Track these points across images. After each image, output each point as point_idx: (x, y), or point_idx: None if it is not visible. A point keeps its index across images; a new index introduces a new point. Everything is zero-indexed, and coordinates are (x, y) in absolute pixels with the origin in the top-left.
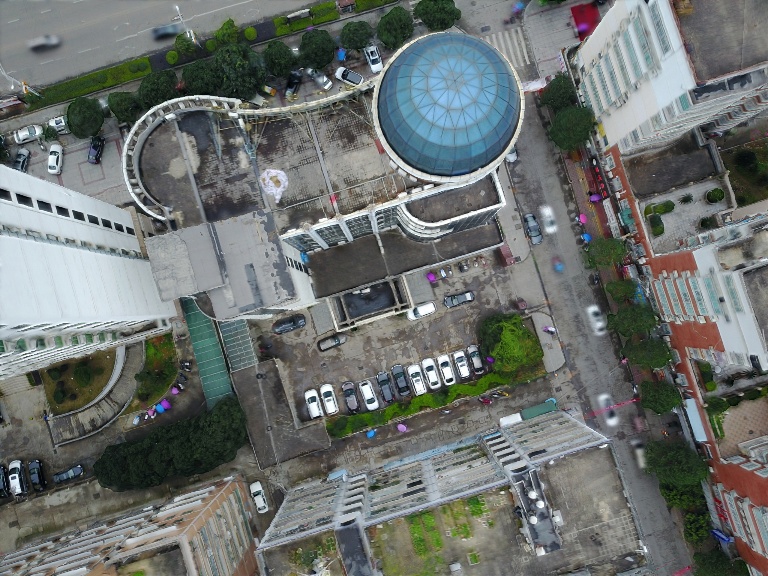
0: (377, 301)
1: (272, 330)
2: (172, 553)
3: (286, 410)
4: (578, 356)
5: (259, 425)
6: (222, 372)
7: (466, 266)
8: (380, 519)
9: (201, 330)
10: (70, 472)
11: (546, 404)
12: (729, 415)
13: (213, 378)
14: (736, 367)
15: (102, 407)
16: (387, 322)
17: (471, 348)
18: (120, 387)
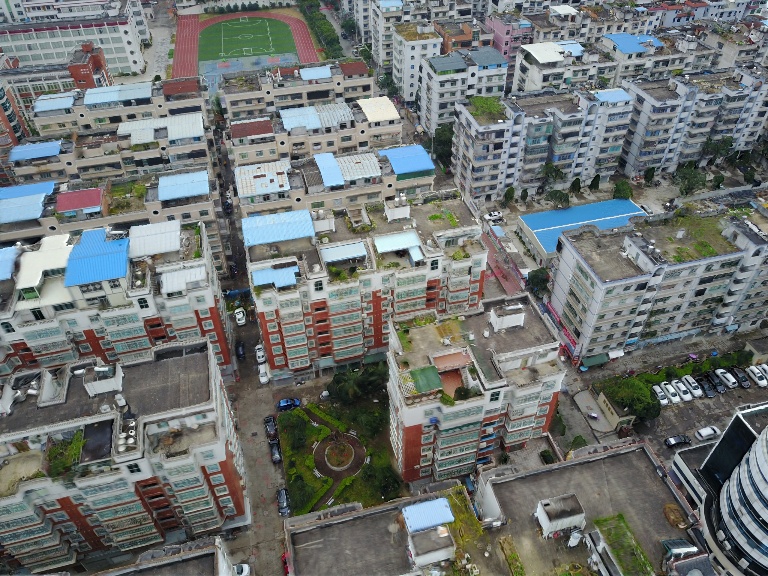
0: None
1: None
2: None
3: None
4: (563, 402)
5: None
6: None
7: None
8: None
9: None
10: None
11: (590, 364)
12: None
13: None
14: None
15: None
16: None
17: None
18: None
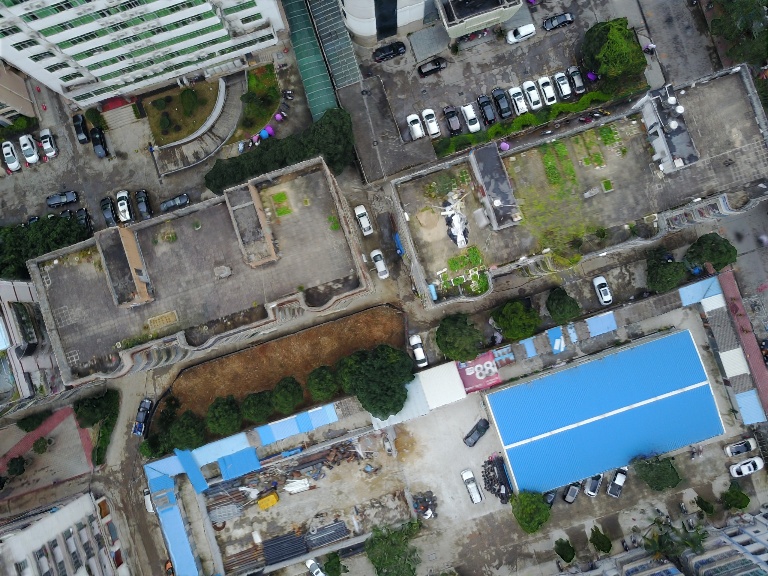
0: (482, 9)
1: (372, 58)
2: (313, 175)
3: (391, 125)
4: (678, 77)
5: (365, 140)
6: (328, 88)
7: None
8: None
9: (306, 47)
10: (177, 200)
11: None
12: None
13: (319, 94)
14: None
15: (205, 140)
16: (486, 48)
17: (571, 69)
18: (222, 122)
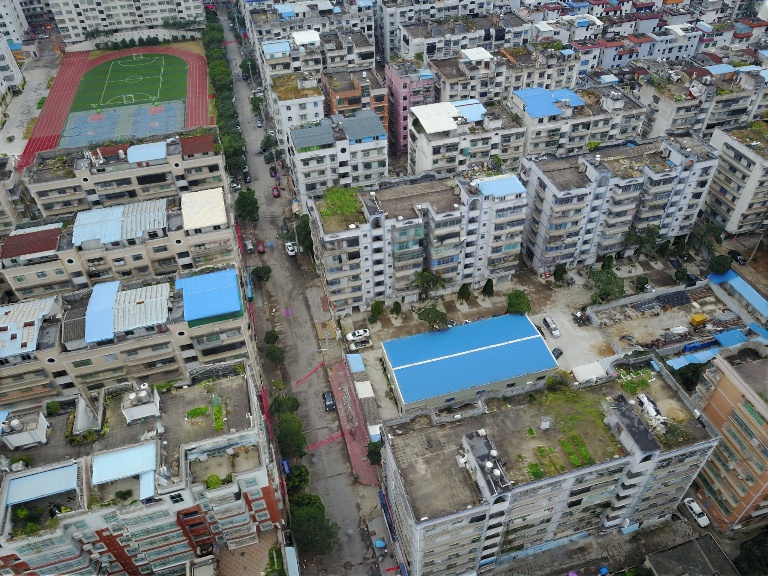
0: None
1: None
2: None
3: None
4: None
5: None
6: None
7: None
8: (618, 462)
9: None
10: None
11: None
12: (260, 571)
13: None
14: None
15: None
16: None
17: None
18: None
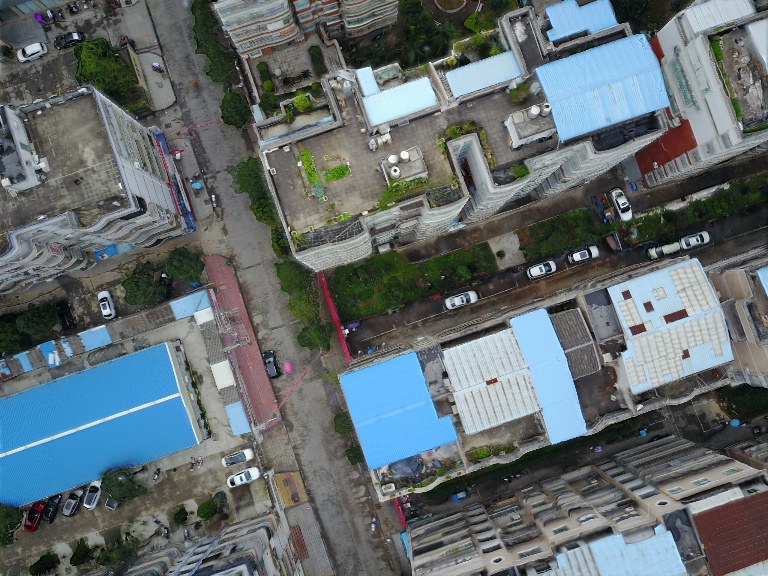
0: None
1: None
2: None
3: None
4: (189, 94)
5: None
6: None
7: (75, 8)
8: None
9: None
10: None
11: None
12: None
13: None
14: (298, 71)
15: None
16: (1, 66)
17: None
18: None
